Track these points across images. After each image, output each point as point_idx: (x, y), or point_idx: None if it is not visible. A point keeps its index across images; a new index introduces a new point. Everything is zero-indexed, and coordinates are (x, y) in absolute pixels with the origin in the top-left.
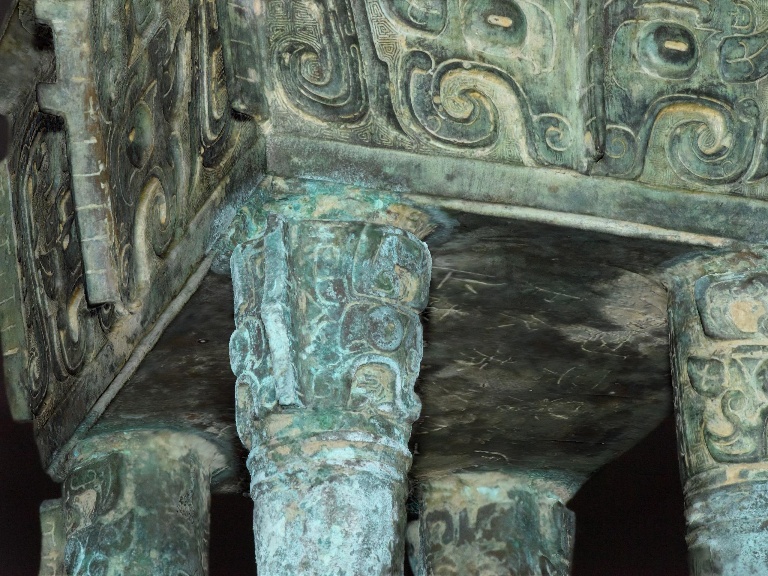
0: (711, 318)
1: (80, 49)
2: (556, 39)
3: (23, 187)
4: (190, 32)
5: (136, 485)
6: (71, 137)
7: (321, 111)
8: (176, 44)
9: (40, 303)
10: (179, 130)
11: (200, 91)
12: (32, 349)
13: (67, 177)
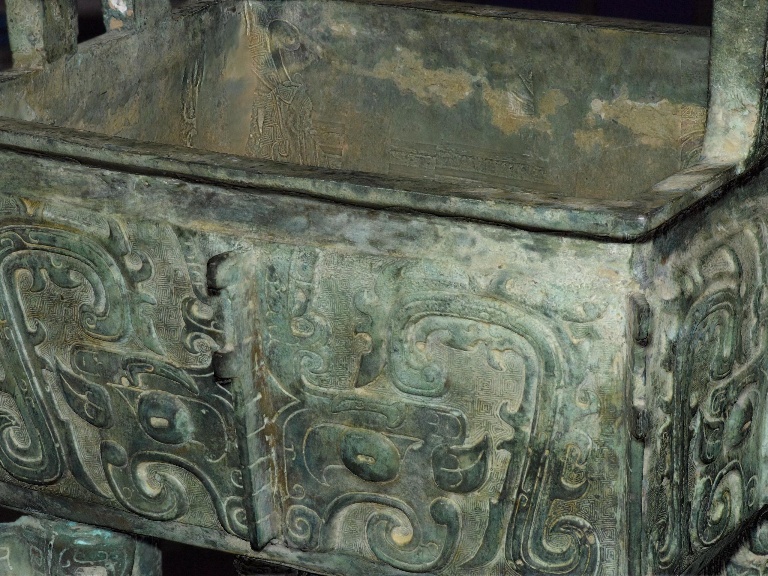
0: (759, 541)
1: (247, 308)
2: (759, 411)
3: (1, 264)
4: (508, 451)
5: (140, 557)
6: (245, 400)
7: (667, 575)
8: (484, 451)
9: (41, 395)
10: (460, 505)
11: (527, 518)
12: (8, 415)
13: (169, 370)
